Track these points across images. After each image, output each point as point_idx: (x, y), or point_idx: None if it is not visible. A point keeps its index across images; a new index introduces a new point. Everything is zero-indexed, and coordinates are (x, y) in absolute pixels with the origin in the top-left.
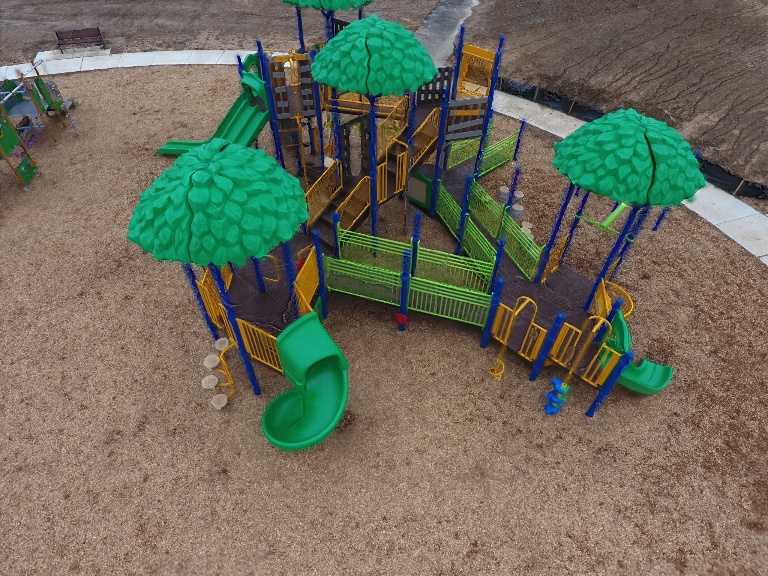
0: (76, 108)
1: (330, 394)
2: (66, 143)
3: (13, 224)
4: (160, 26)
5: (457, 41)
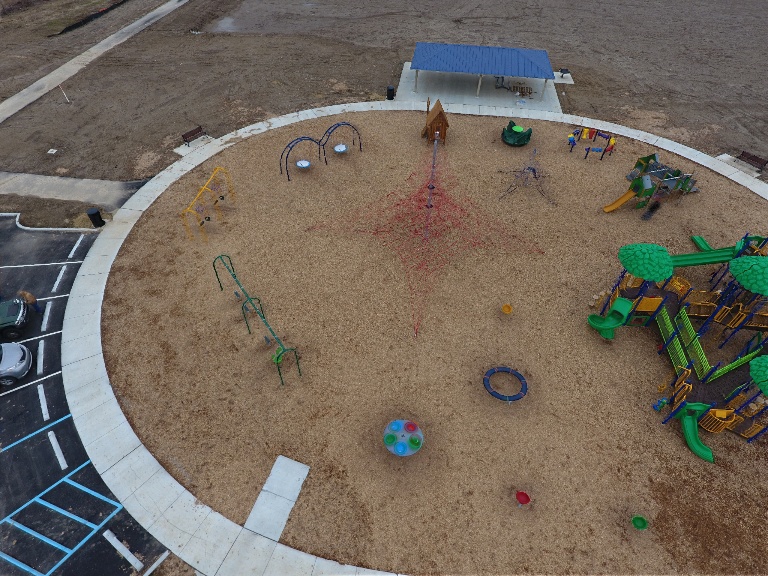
0: (695, 193)
1: (612, 324)
2: (669, 205)
3: (615, 218)
4: None
5: None
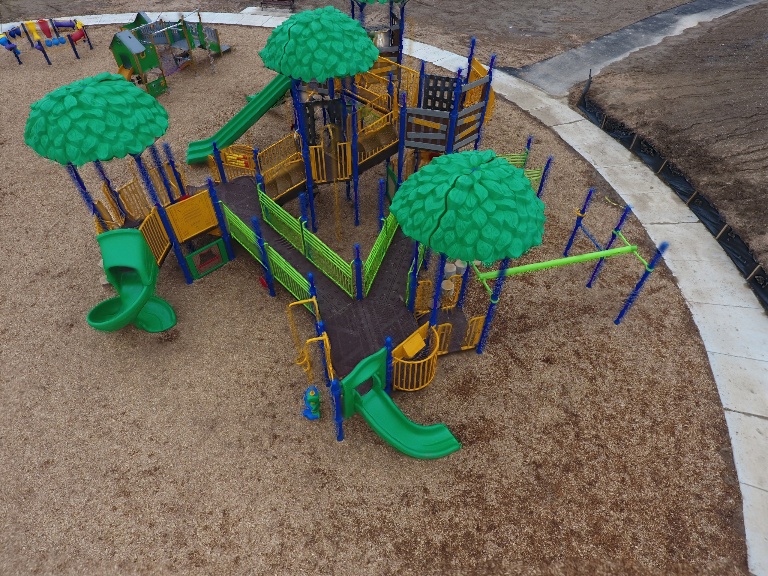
0: (231, 53)
1: (134, 300)
2: (203, 76)
3: None
4: (345, 2)
5: (607, 68)
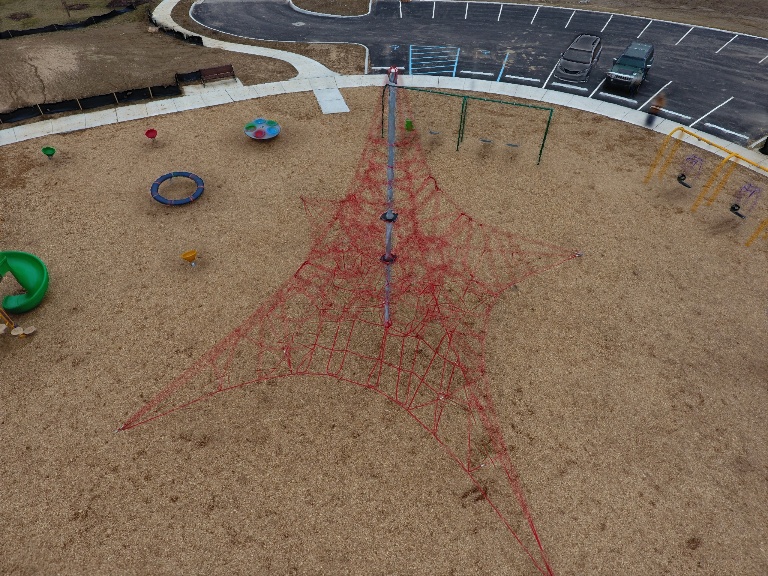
0: None
1: None
2: None
3: None
4: None
5: None
